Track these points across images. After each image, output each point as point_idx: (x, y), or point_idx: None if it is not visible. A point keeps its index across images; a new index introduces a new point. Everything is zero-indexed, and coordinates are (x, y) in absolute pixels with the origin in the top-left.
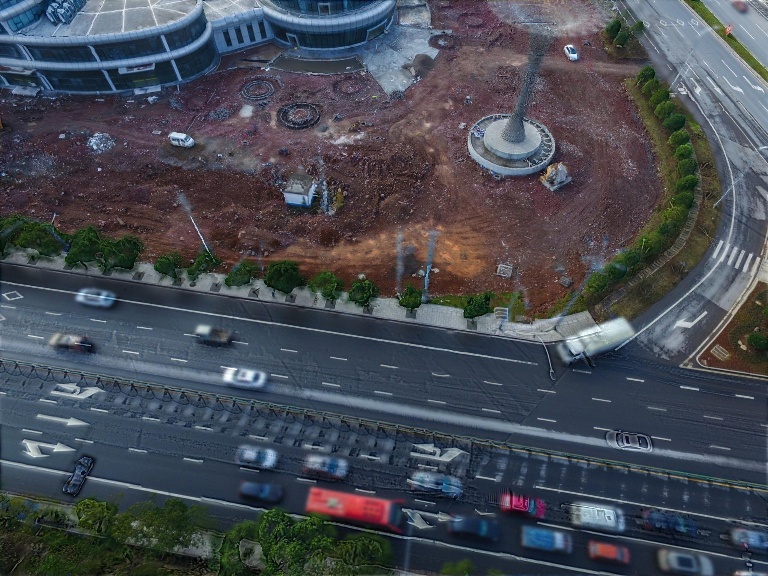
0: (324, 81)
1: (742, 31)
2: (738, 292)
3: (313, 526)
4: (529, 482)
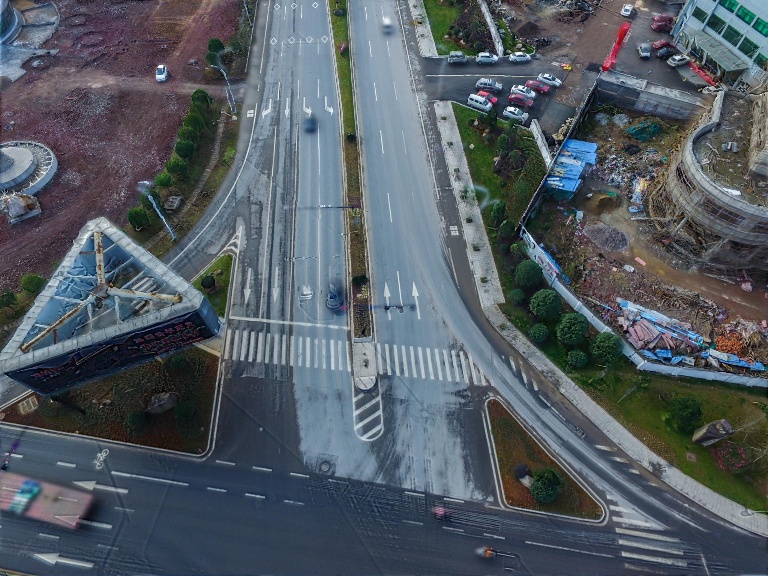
0: None
1: (366, 48)
2: None
3: None
4: None
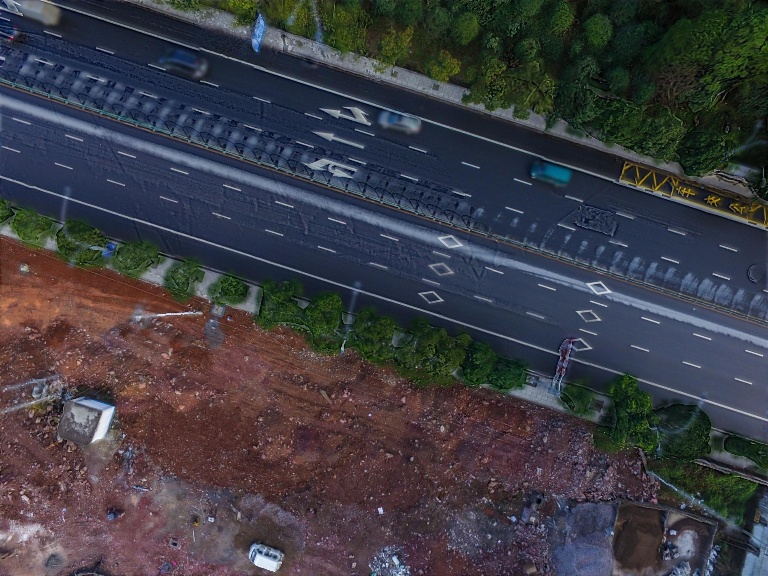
0: None
1: None
2: None
3: None
4: None
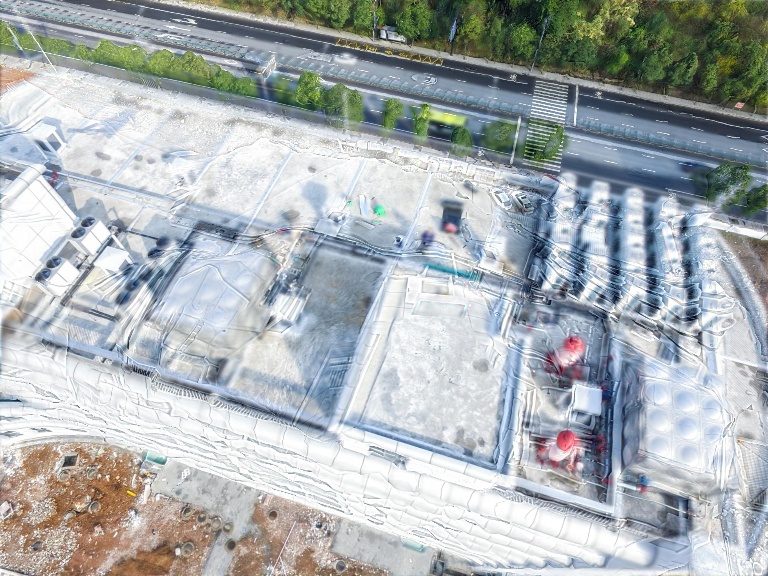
0: None
1: None
2: None
3: None
4: None
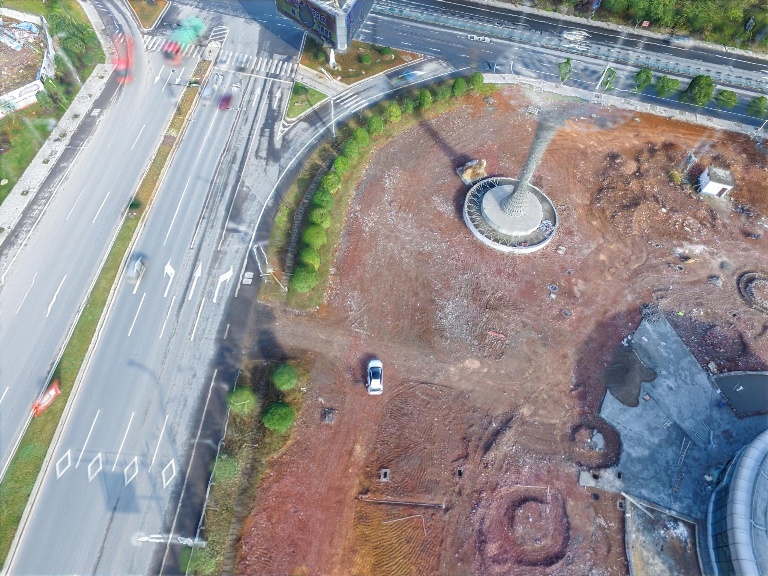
0: (764, 356)
1: (2, 417)
2: (369, 83)
3: (642, 1)
4: (532, 35)
